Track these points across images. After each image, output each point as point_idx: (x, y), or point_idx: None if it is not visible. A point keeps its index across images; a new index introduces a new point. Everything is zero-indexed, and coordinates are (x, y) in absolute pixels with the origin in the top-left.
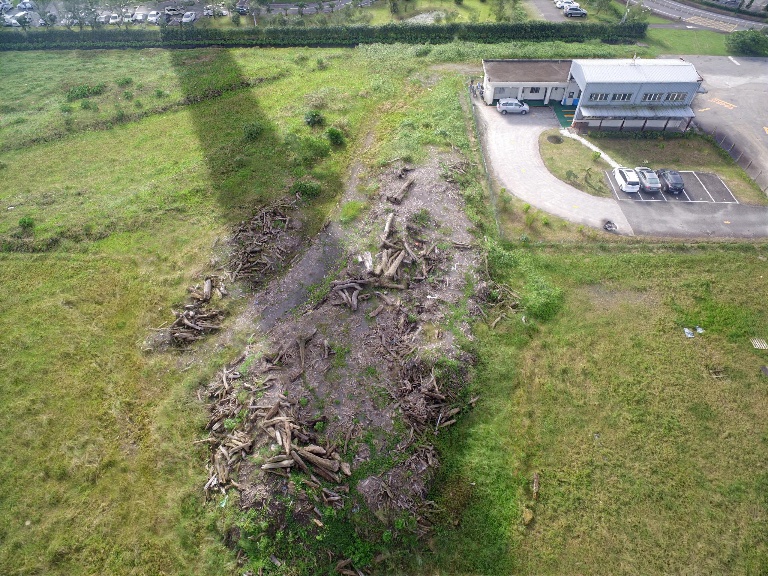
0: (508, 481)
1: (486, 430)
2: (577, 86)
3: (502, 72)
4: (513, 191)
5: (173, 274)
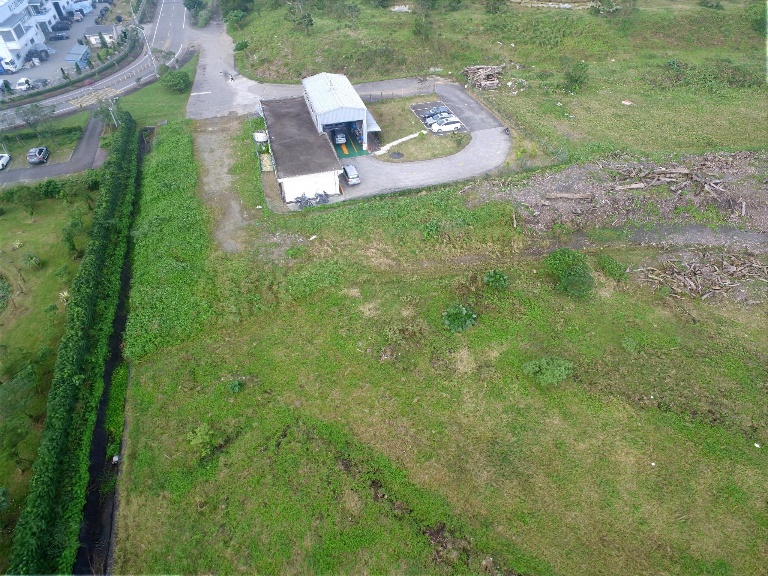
0: None
1: None
2: None
3: (308, 167)
4: (496, 166)
5: None
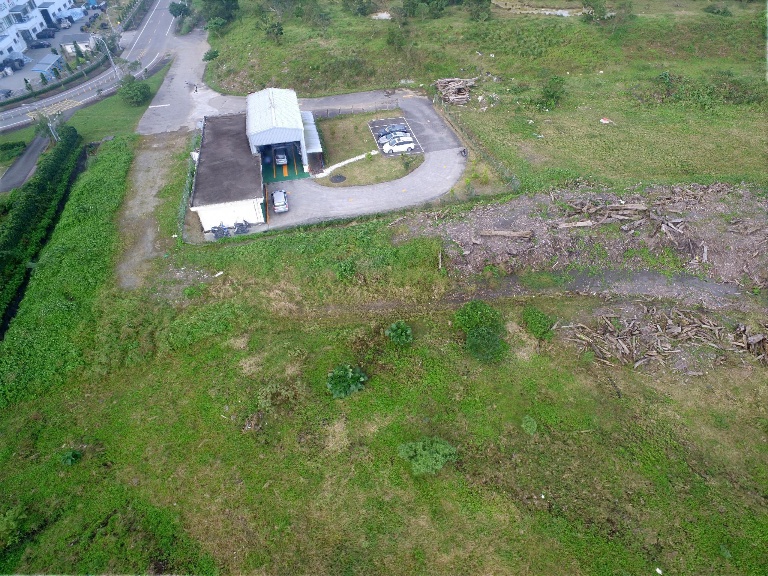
0: None
1: None
2: None
3: (228, 193)
4: (441, 193)
5: None
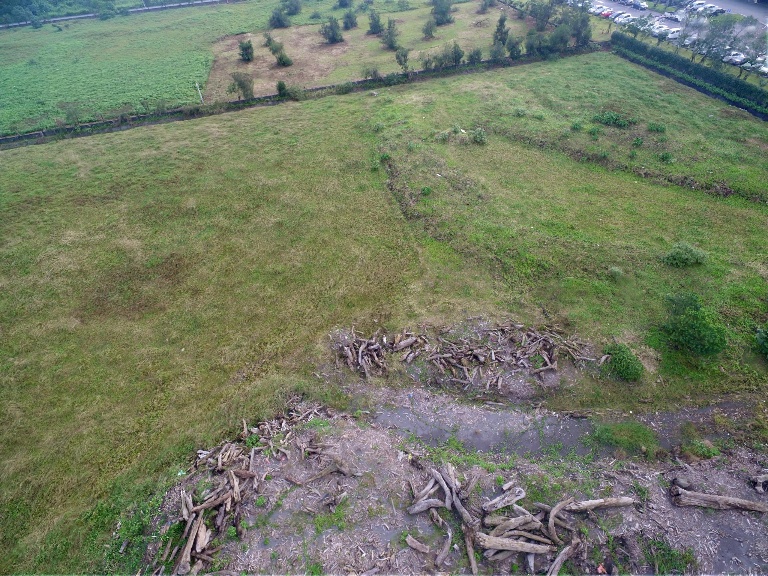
0: None
1: None
2: None
3: None
4: None
5: (420, 308)
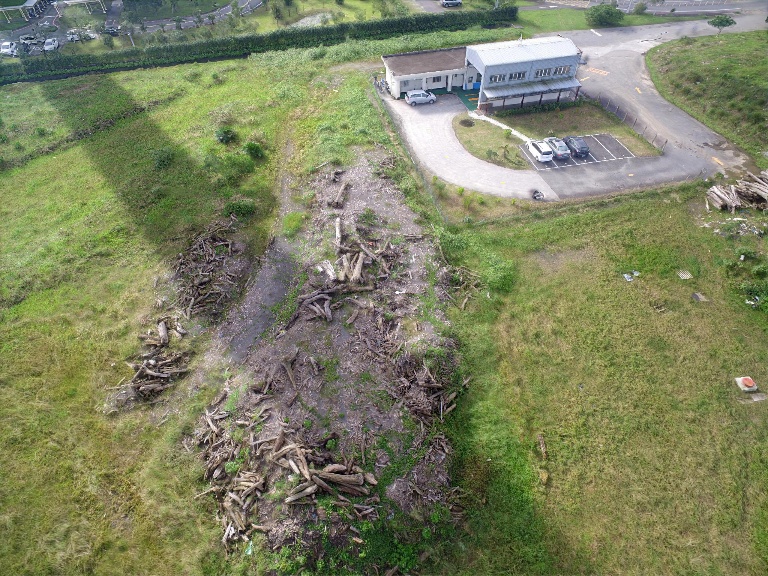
0: (518, 449)
1: (485, 407)
2: (474, 71)
3: (403, 66)
4: (443, 177)
5: (117, 325)
